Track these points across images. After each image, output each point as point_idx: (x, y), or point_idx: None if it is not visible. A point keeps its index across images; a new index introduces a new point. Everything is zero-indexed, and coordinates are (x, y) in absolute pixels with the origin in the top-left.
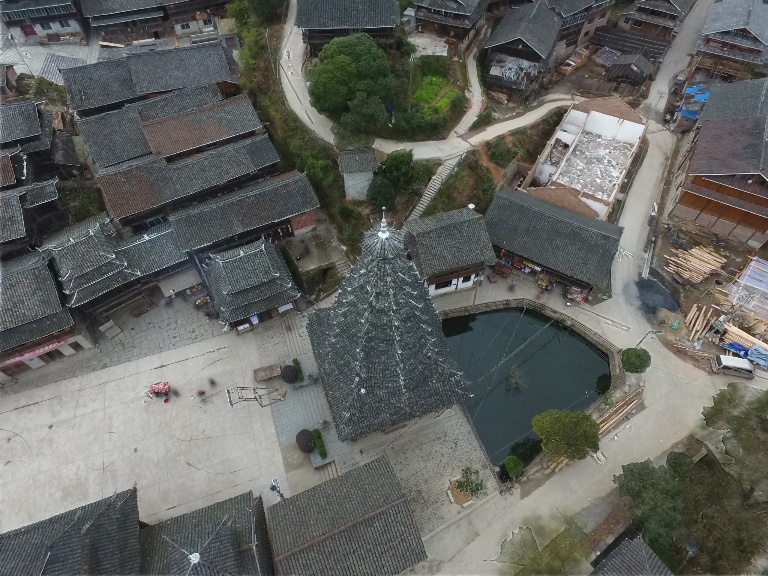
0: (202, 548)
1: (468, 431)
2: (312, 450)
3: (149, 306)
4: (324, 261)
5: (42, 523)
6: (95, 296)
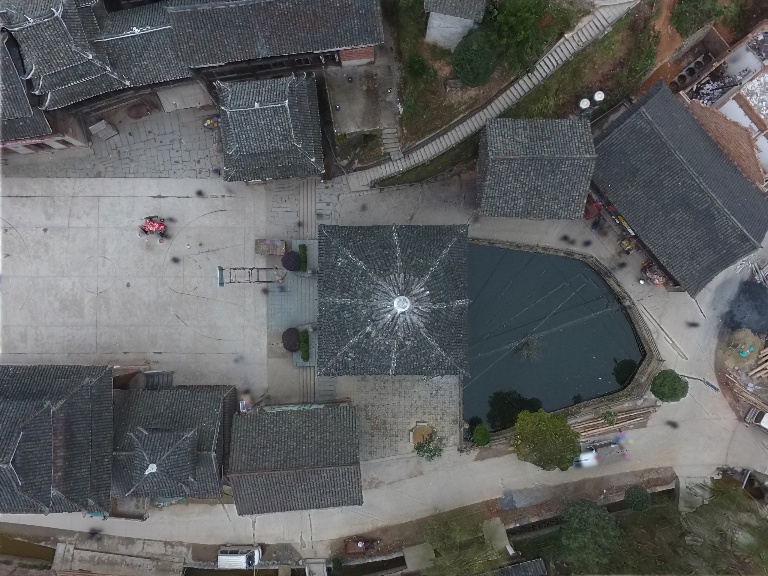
0: (160, 460)
1: (455, 384)
2: (296, 350)
3: (150, 108)
4: (369, 123)
5: (27, 369)
6: (74, 101)
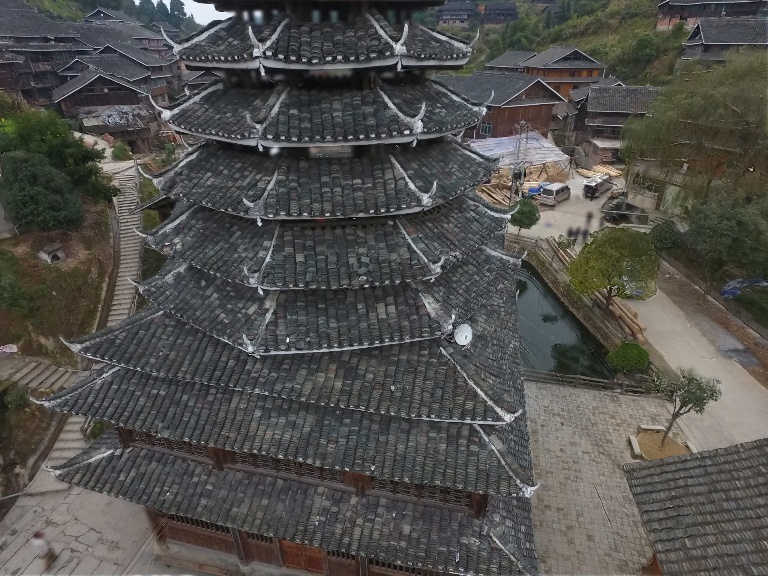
0: None
1: (537, 388)
2: None
3: None
4: None
5: None
6: None
